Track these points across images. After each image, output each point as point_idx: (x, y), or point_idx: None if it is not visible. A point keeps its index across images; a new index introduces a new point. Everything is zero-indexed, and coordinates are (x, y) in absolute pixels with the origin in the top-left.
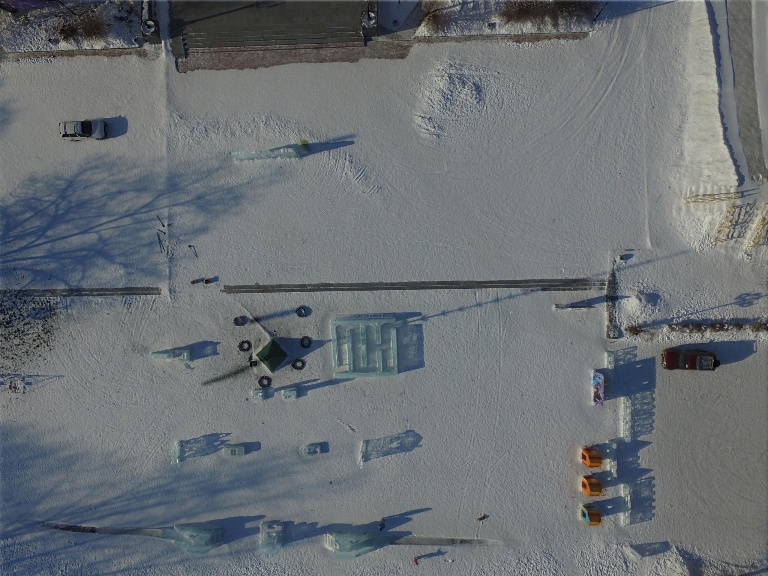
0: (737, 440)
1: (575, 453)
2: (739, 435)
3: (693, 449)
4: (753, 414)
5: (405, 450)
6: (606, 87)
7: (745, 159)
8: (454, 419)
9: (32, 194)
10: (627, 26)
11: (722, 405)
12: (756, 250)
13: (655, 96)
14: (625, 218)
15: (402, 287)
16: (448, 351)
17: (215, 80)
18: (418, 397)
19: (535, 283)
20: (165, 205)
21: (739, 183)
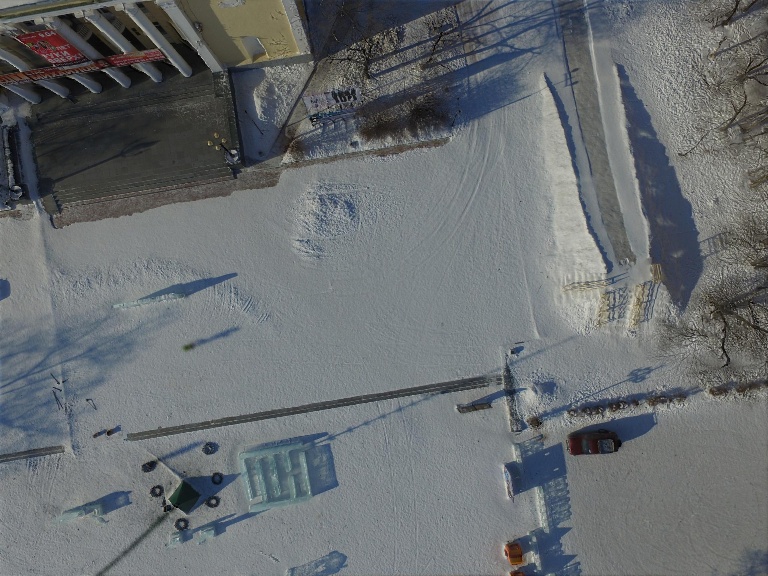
0: (653, 513)
1: (499, 550)
2: (654, 507)
3: (612, 528)
4: (664, 485)
5: (331, 572)
6: (473, 188)
7: (611, 245)
8: (375, 534)
9: None
10: (484, 127)
11: (633, 480)
12: (639, 327)
13: (521, 190)
14: (510, 312)
15: (304, 410)
16: (359, 467)
17: (92, 231)
18: (336, 517)
19: (434, 387)
20: (57, 362)
21: (608, 270)
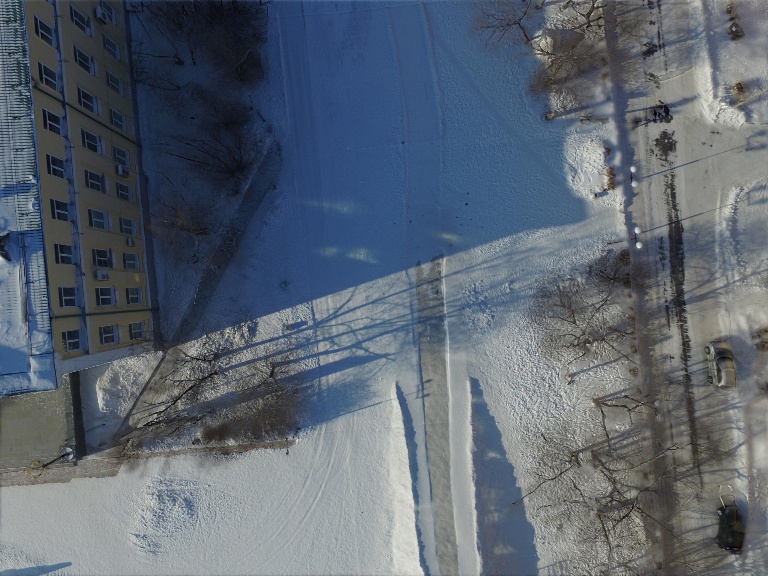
0: None
1: None
2: None
3: None
4: None
5: None
6: (315, 494)
7: None
8: None
9: None
10: (332, 431)
11: None
12: None
13: (363, 501)
14: None
15: None
16: None
17: None
18: None
19: None
20: None
21: None
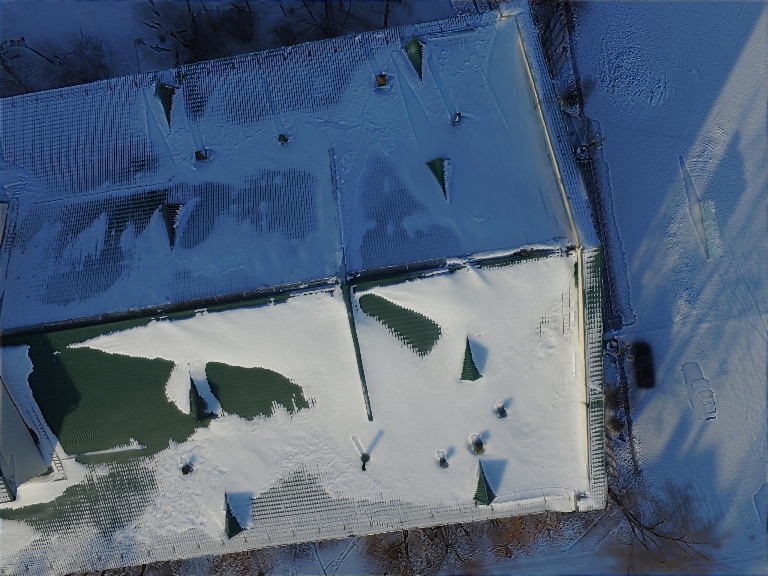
0: None
1: None
2: None
3: None
4: None
5: None
6: None
7: None
8: None
9: (764, 443)
10: None
11: None
12: None
13: None
14: None
15: None
16: None
17: (638, 288)
18: None
19: None
20: (759, 318)
21: None
